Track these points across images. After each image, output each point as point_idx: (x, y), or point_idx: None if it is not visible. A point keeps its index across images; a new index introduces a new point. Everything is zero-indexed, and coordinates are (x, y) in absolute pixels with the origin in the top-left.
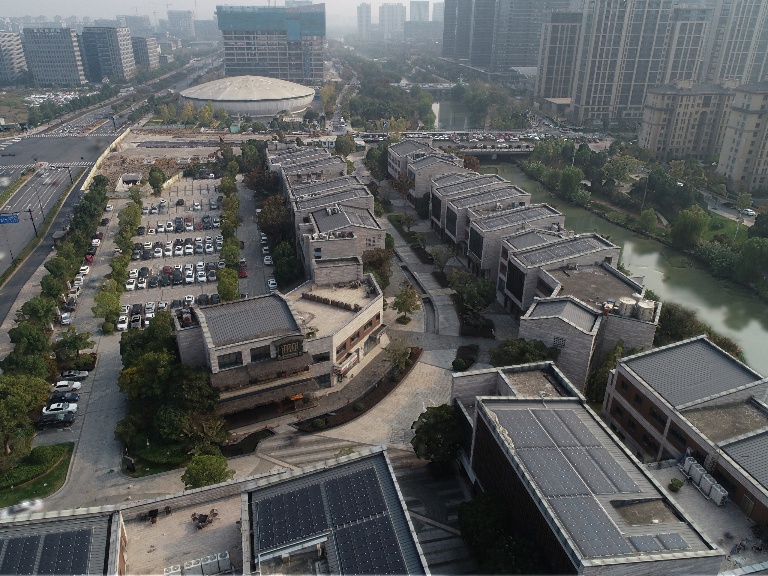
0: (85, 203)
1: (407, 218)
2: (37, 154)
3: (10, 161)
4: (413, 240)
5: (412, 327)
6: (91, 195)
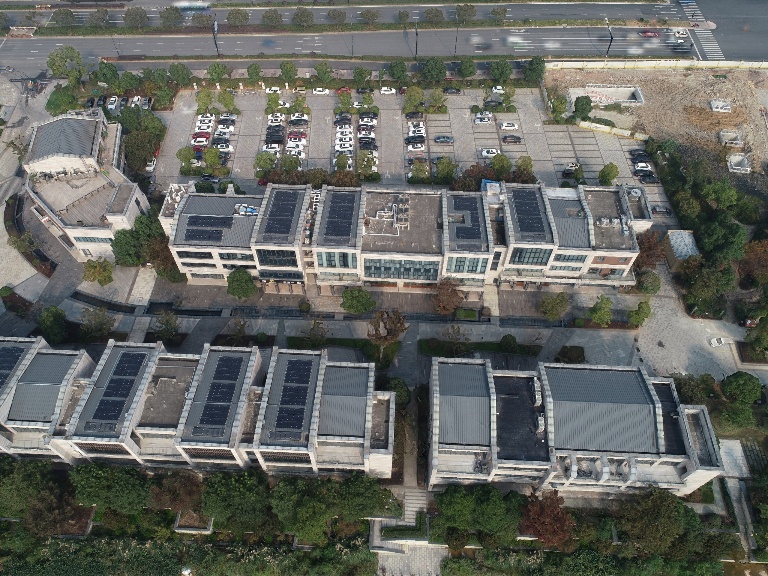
0: (430, 60)
1: (318, 333)
2: (760, 15)
3: (719, 3)
4: (290, 343)
5: (90, 283)
6: (467, 62)
